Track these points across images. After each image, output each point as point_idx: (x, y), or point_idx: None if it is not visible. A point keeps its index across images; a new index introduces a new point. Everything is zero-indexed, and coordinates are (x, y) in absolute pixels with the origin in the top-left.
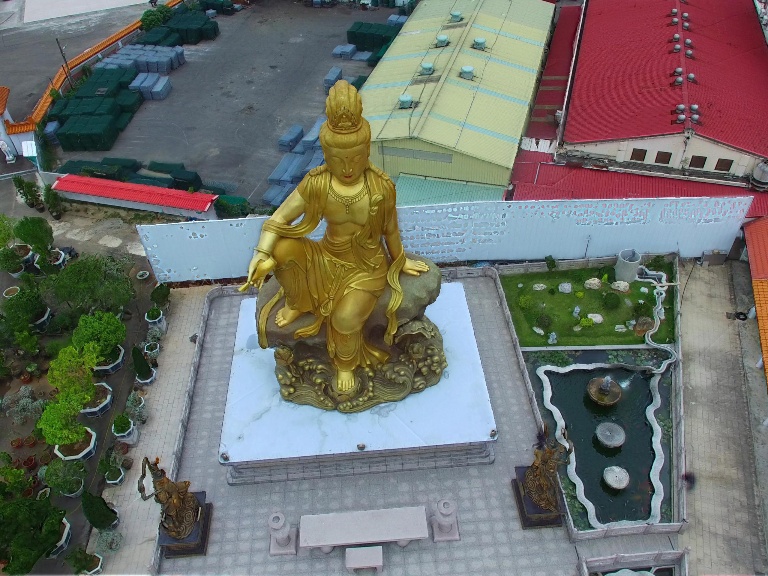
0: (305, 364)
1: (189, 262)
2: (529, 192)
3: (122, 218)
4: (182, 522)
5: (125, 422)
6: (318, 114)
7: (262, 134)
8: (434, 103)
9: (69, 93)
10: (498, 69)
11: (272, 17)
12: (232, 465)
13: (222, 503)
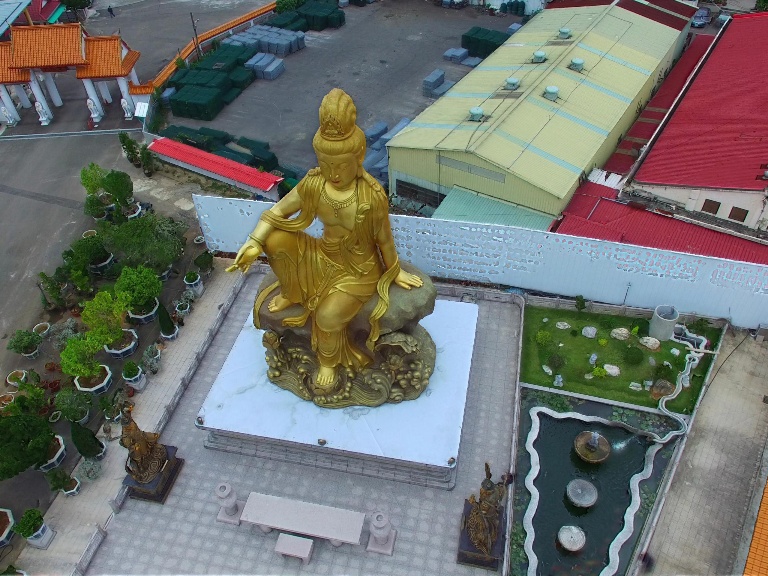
0: (293, 352)
1: (235, 236)
2: (576, 226)
3: (201, 185)
4: (147, 469)
5: (133, 369)
6: (409, 114)
7: None
8: (504, 120)
9: (194, 63)
10: (588, 93)
11: (399, 12)
12: (205, 429)
13: (193, 462)
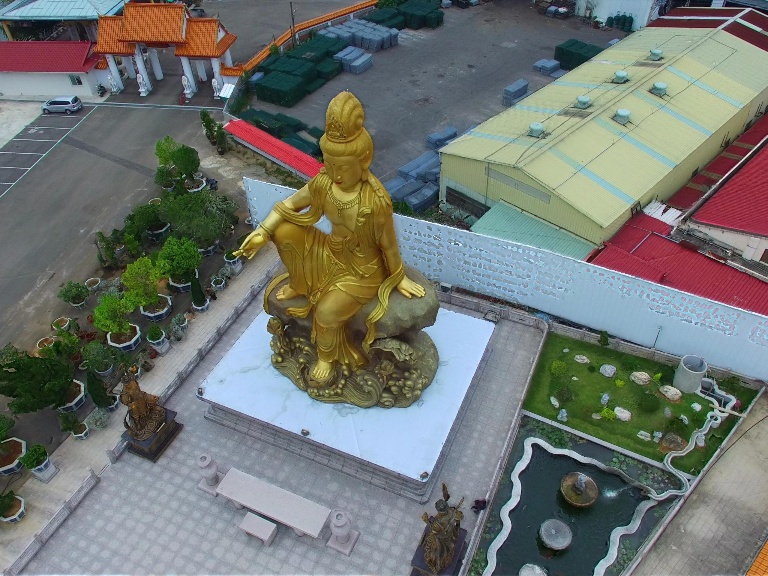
0: (297, 341)
1: None
2: (615, 258)
3: (266, 168)
4: (144, 427)
5: (156, 332)
6: None
7: (421, 127)
8: (563, 139)
9: (289, 51)
10: (665, 121)
11: (500, 18)
12: (204, 400)
13: (191, 429)
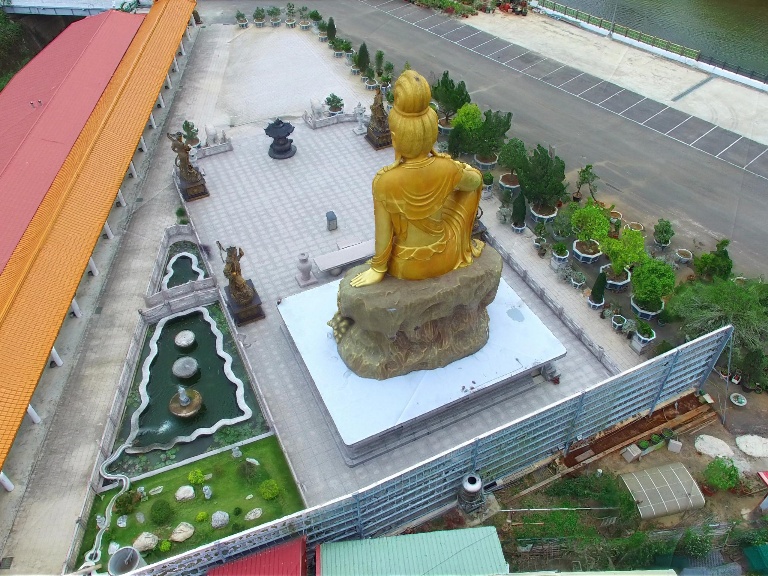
0: None
1: None
2: None
3: None
4: None
5: None
6: None
7: None
8: None
9: None
10: None
11: None
12: None
13: None
